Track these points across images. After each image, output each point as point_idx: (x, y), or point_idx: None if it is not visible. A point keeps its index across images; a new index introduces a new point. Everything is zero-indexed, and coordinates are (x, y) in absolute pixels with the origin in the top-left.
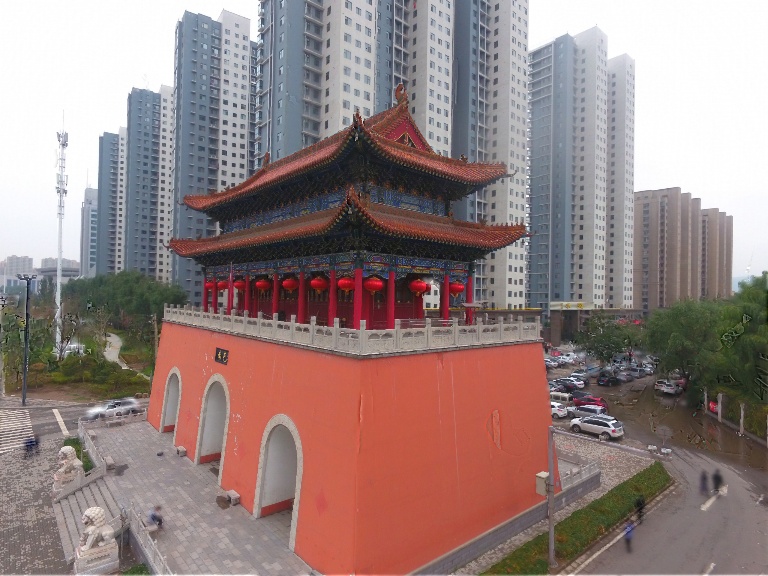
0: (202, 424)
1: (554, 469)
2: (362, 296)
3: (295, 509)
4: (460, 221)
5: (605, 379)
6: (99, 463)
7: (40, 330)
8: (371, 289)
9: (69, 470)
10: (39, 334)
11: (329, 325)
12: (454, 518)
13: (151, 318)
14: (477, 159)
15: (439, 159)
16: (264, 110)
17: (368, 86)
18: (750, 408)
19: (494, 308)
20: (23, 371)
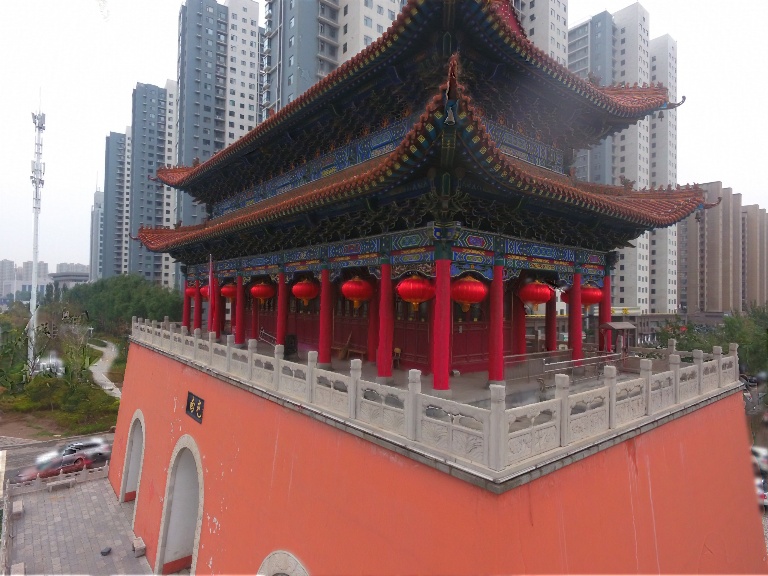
0: (166, 512)
1: None
2: None
3: None
4: (588, 183)
5: None
6: None
7: (6, 345)
8: (464, 300)
9: None
10: (6, 349)
11: (379, 368)
12: None
13: None
14: None
15: None
16: (272, 89)
17: None
18: None
19: (533, 315)
20: None
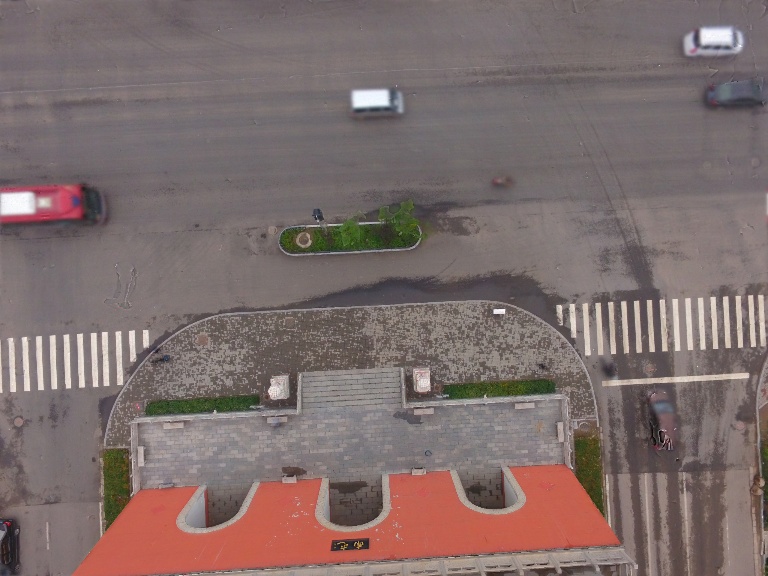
0: None
1: None
2: None
3: (193, 499)
4: None
5: None
6: None
7: None
8: None
9: None
10: None
11: None
12: None
13: None
14: None
15: None
16: None
17: None
18: None
19: None
20: None
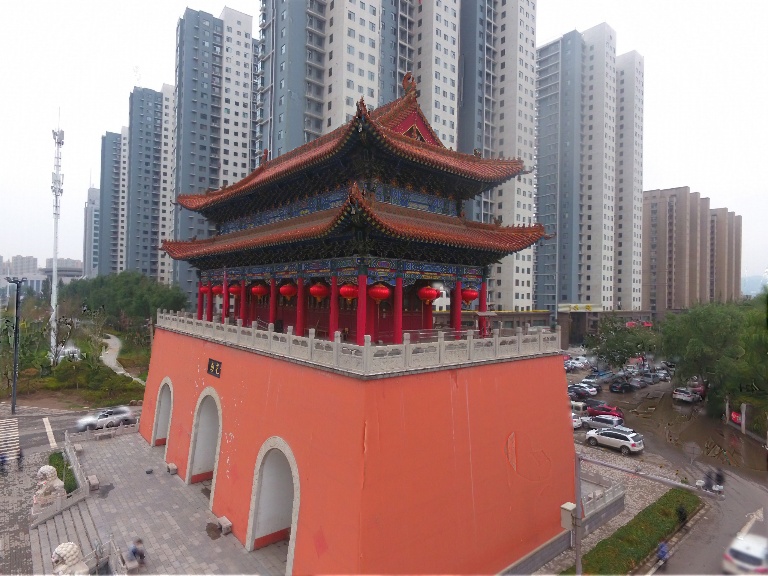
0: (194, 441)
1: None
2: (366, 304)
3: (291, 546)
4: (473, 222)
5: (618, 386)
6: (82, 483)
7: (34, 334)
8: (376, 297)
9: (49, 491)
10: (33, 338)
11: (330, 337)
12: (469, 556)
13: (147, 322)
14: None
15: (450, 154)
16: (265, 107)
17: (372, 82)
18: None
19: (501, 310)
20: (12, 378)
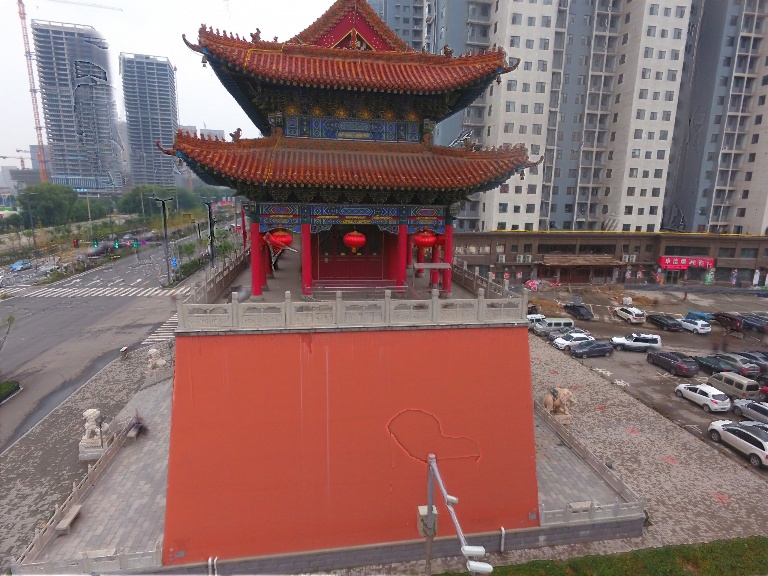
0: None
1: (529, 497)
2: None
3: None
4: (440, 147)
5: None
6: None
7: None
8: None
9: None
10: None
11: None
12: (319, 519)
13: None
14: (745, 8)
15: (412, 59)
16: (431, 3)
17: None
18: None
19: (737, 233)
20: None
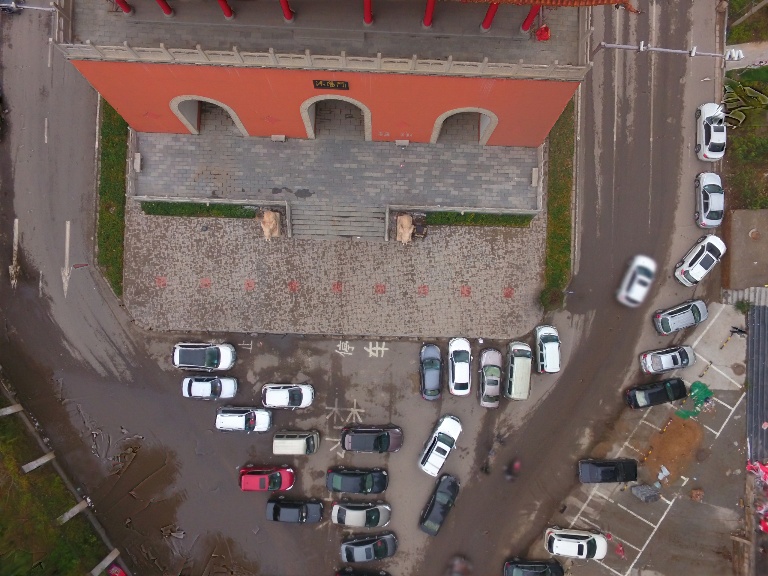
0: None
1: None
2: None
3: None
4: None
5: None
6: None
7: None
8: None
9: None
10: None
11: None
12: None
13: None
14: None
15: None
16: None
17: None
18: (51, 508)
19: None
20: None
